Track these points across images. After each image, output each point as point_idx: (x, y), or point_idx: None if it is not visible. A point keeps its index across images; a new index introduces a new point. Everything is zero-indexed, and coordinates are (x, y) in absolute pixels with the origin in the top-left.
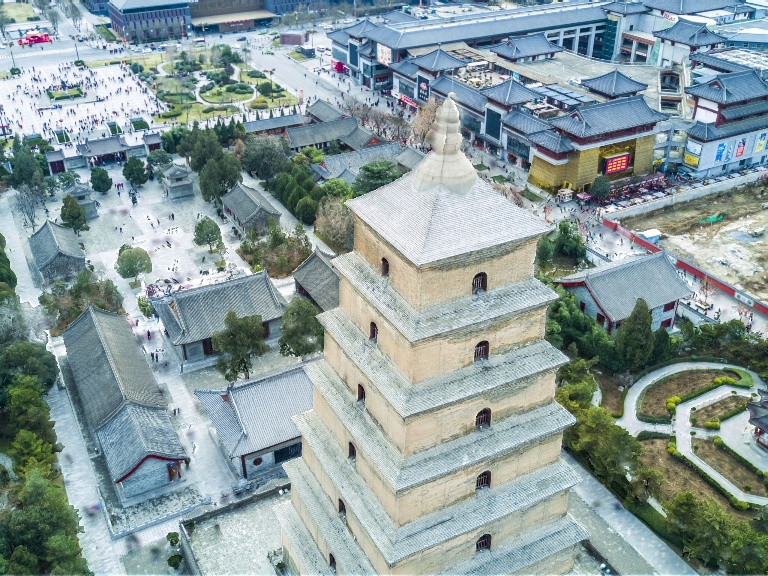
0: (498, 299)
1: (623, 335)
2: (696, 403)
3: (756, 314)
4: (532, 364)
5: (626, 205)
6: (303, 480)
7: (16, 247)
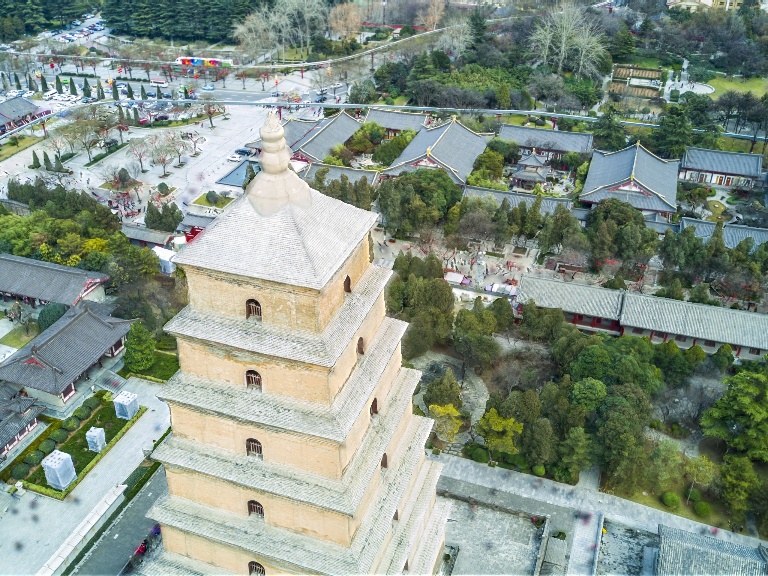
0: None
1: None
2: None
3: None
4: None
5: None
6: None
7: None
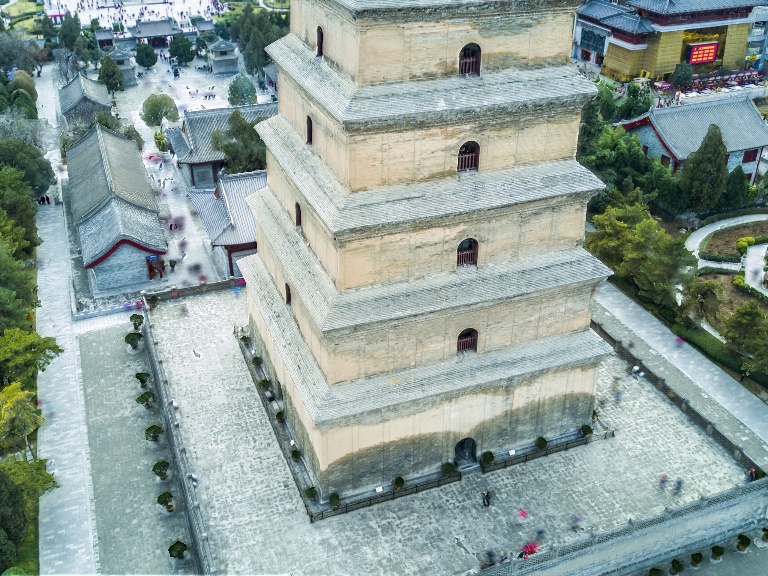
0: None
1: (689, 168)
2: None
3: None
4: None
5: (710, 93)
6: (264, 205)
7: (49, 104)
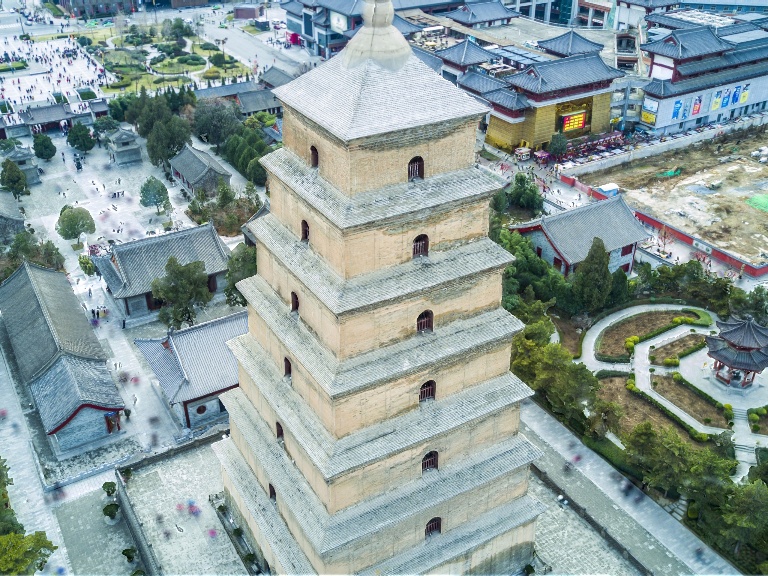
0: (436, 187)
1: (580, 276)
2: (655, 342)
3: (714, 261)
4: (475, 262)
5: (584, 162)
6: (240, 409)
7: None
